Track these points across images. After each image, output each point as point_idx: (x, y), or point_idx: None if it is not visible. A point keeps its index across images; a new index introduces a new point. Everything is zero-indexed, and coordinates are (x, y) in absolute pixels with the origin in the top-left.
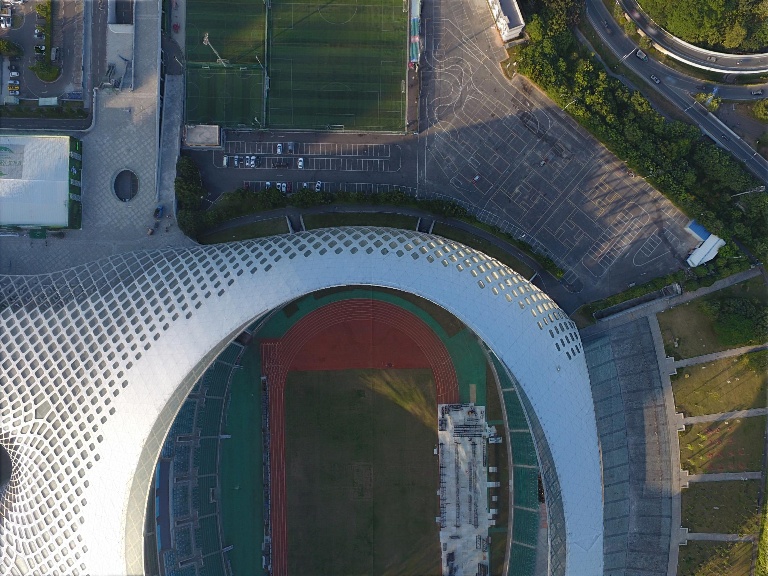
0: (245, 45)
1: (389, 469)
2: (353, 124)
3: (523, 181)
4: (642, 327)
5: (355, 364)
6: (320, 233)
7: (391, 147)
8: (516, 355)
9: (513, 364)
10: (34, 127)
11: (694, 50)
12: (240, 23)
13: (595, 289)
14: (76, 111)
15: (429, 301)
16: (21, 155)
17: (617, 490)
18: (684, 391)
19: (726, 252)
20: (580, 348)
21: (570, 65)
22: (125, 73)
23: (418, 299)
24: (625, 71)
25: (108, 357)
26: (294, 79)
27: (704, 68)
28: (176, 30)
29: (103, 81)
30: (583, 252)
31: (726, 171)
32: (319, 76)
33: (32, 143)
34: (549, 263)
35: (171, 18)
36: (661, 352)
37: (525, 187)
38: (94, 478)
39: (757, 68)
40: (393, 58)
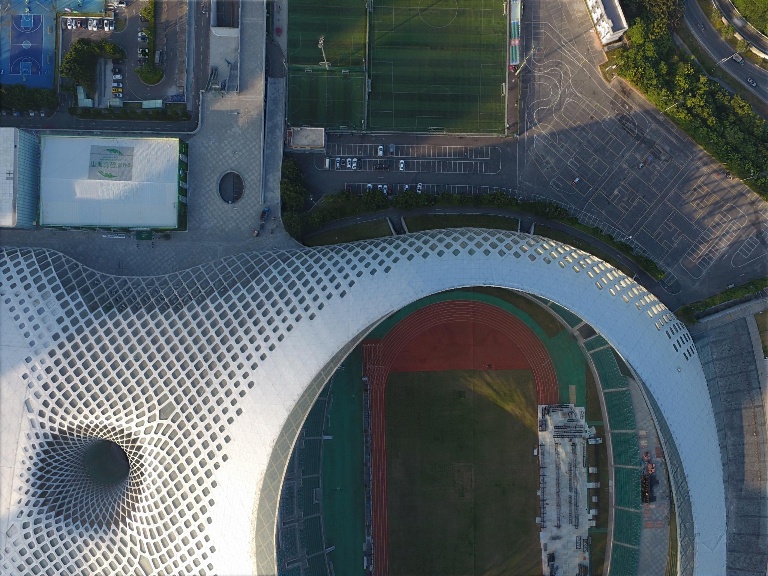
0: (346, 48)
1: (490, 470)
2: (453, 126)
3: (622, 183)
4: (740, 328)
5: (456, 365)
6: (433, 235)
7: (491, 149)
8: (640, 356)
9: (638, 365)
10: (138, 129)
11: None
12: (342, 26)
13: (694, 290)
14: (181, 113)
15: (529, 302)
16: (130, 157)
17: None
18: None
19: None
20: (694, 349)
21: (668, 68)
22: (229, 76)
23: (518, 300)
24: (722, 74)
25: (232, 358)
26: (395, 82)
27: None
28: (279, 33)
29: (212, 84)
30: (682, 254)
31: None
32: (420, 79)
33: (141, 145)
34: (651, 264)
35: (273, 21)
36: (759, 353)
37: (624, 189)
38: (222, 478)
39: None
40: (493, 61)
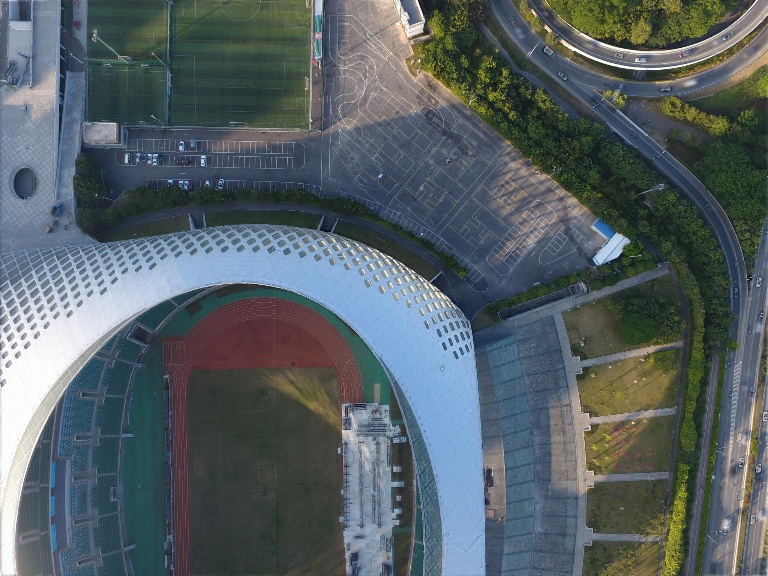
0: (147, 42)
1: (292, 468)
2: (256, 121)
3: (428, 179)
4: (548, 326)
5: (258, 363)
6: (211, 231)
7: (295, 145)
8: (397, 354)
9: (392, 363)
10: None
11: (601, 46)
12: (142, 20)
13: (500, 288)
14: None
15: None
16: None
17: (521, 490)
18: (590, 391)
19: (630, 251)
20: (471, 347)
21: (476, 62)
22: (25, 70)
23: None
24: (532, 68)
25: None
26: (197, 76)
27: (611, 65)
28: (77, 27)
29: None
30: (488, 250)
31: (630, 169)
32: (222, 73)
33: None
34: (451, 262)
35: (73, 15)
36: (567, 351)
37: (430, 185)
38: None
39: (664, 65)
40: (297, 55)
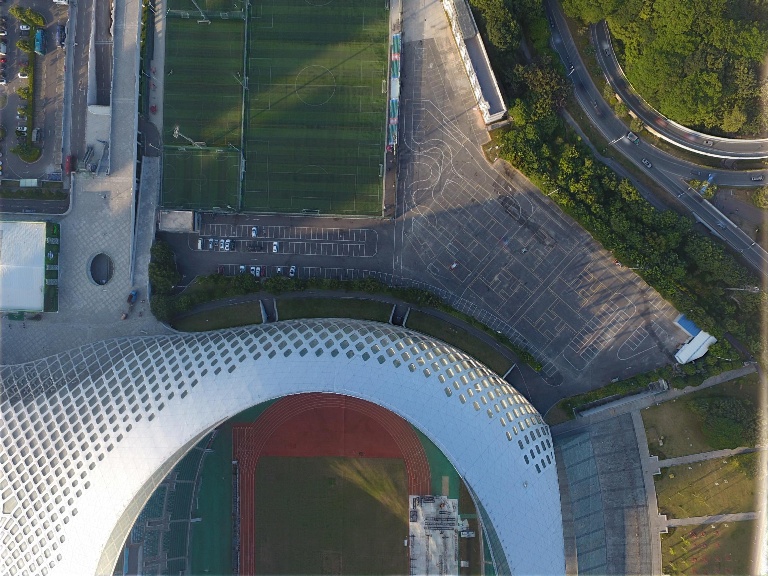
0: (222, 126)
1: (358, 558)
2: (329, 208)
3: (503, 269)
4: (625, 424)
5: (326, 451)
6: (287, 329)
7: (367, 232)
8: (480, 472)
9: (476, 482)
10: (15, 208)
11: (689, 133)
12: (217, 104)
13: (576, 383)
14: (55, 193)
15: None
16: None
17: None
18: (668, 492)
19: (717, 351)
20: (552, 458)
21: (556, 148)
22: (103, 156)
23: None
24: (614, 154)
25: (73, 456)
26: (270, 161)
27: (700, 153)
28: (153, 112)
29: (79, 168)
30: (564, 344)
31: (719, 265)
32: (295, 158)
33: (10, 228)
34: (527, 357)
35: (149, 99)
36: (644, 450)
37: (505, 275)
38: None
39: (758, 154)
40: (371, 140)
